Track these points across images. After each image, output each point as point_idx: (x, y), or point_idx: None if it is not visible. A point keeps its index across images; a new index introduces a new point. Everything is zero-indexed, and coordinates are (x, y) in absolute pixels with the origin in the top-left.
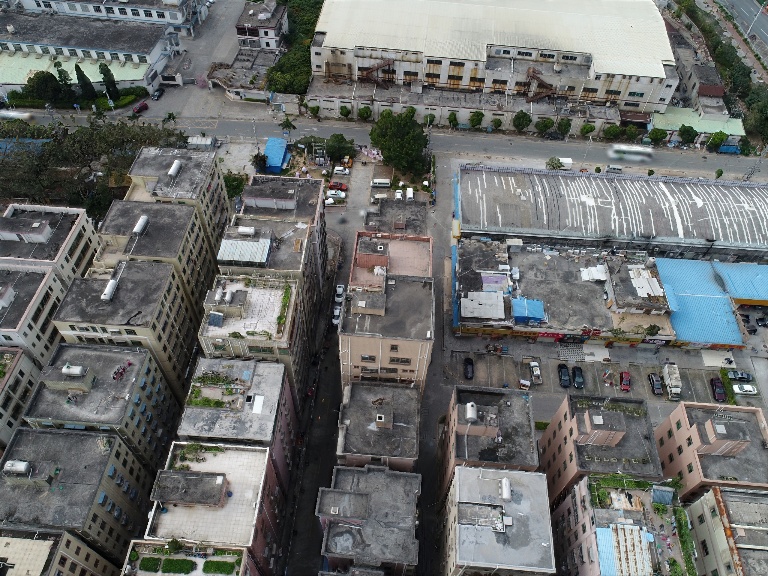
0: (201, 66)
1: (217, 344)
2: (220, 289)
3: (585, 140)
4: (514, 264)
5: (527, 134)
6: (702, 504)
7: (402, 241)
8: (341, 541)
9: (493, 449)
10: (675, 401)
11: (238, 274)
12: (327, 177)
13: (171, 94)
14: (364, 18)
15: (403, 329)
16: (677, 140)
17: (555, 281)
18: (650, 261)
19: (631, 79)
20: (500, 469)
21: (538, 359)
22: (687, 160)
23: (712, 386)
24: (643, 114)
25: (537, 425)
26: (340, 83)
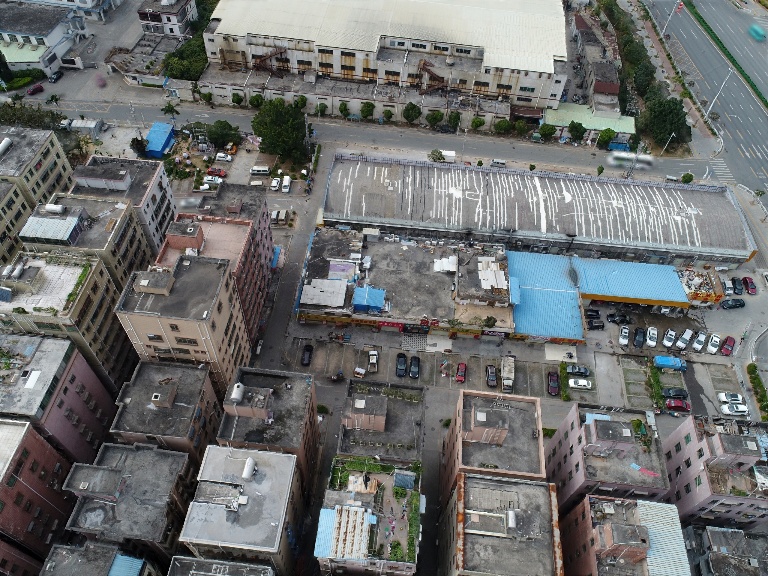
0: (106, 50)
1: (3, 319)
2: (20, 265)
3: (477, 134)
4: (369, 253)
5: (419, 126)
6: (456, 490)
7: (224, 224)
8: (92, 516)
9: (261, 430)
10: (508, 393)
11: (45, 251)
12: (208, 163)
13: (69, 77)
14: (262, 6)
15: (184, 309)
16: (568, 136)
17: (406, 271)
18: (499, 254)
19: (520, 74)
20: (264, 450)
21: (379, 348)
22: (575, 156)
23: (548, 379)
24: (536, 109)
25: None
26: (235, 70)
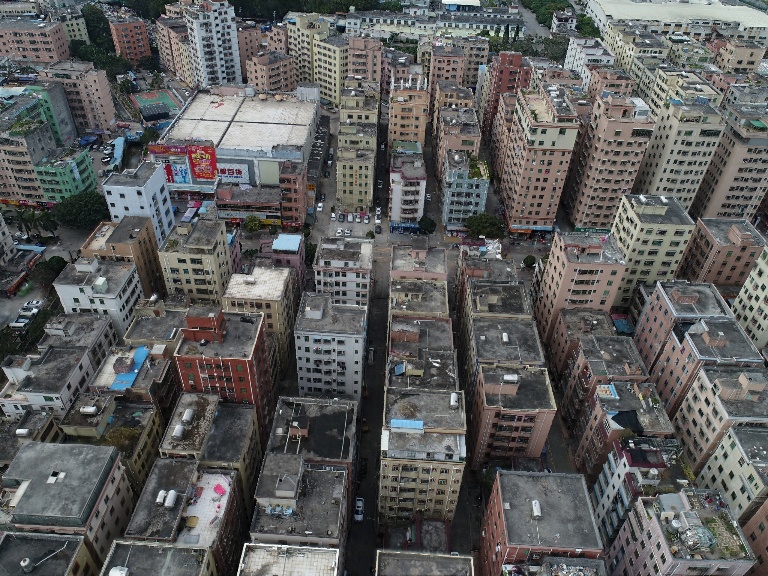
0: (537, 38)
1: (689, 57)
2: None
3: None
4: None
5: None
6: None
7: None
8: None
9: None
10: None
11: None
12: None
13: None
14: (625, 11)
15: None
16: None
17: None
18: None
19: (761, 29)
20: None
21: None
22: None
23: None
24: None
25: None
26: None
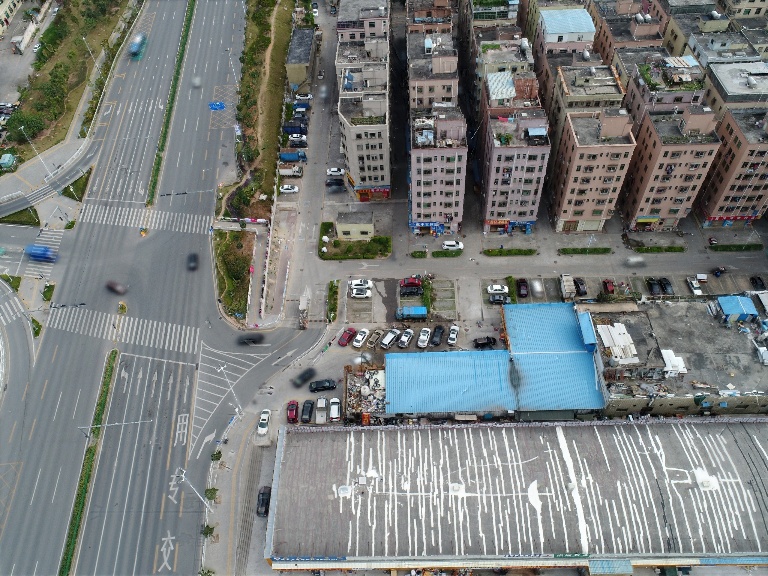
0: None
1: None
2: None
3: None
4: None
5: None
6: None
7: None
8: None
9: None
10: None
11: None
12: None
13: None
14: None
15: None
16: None
17: (713, 353)
18: None
19: None
20: None
21: None
22: None
23: None
24: None
25: (681, 248)
26: None
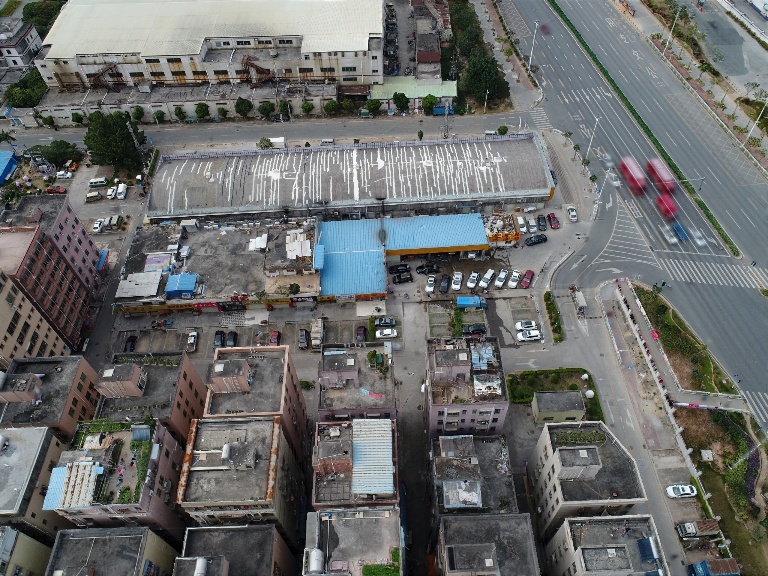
0: None
1: None
2: None
3: (310, 118)
4: (188, 243)
5: (255, 119)
6: None
7: (13, 233)
8: None
9: (29, 412)
10: (318, 352)
11: None
12: (49, 183)
13: None
14: (92, 27)
15: None
16: (396, 108)
17: (222, 254)
18: (304, 225)
19: (337, 55)
20: None
21: (200, 329)
22: (403, 126)
23: (356, 334)
24: (364, 87)
25: None
26: (73, 91)
